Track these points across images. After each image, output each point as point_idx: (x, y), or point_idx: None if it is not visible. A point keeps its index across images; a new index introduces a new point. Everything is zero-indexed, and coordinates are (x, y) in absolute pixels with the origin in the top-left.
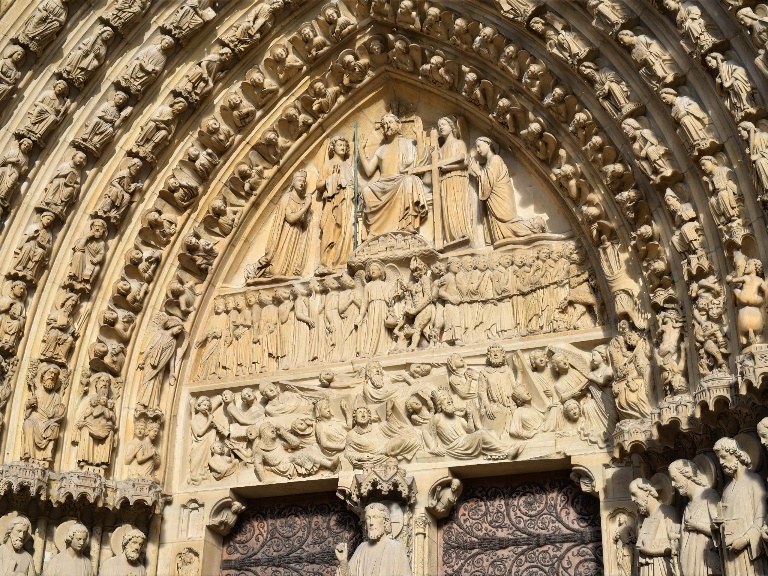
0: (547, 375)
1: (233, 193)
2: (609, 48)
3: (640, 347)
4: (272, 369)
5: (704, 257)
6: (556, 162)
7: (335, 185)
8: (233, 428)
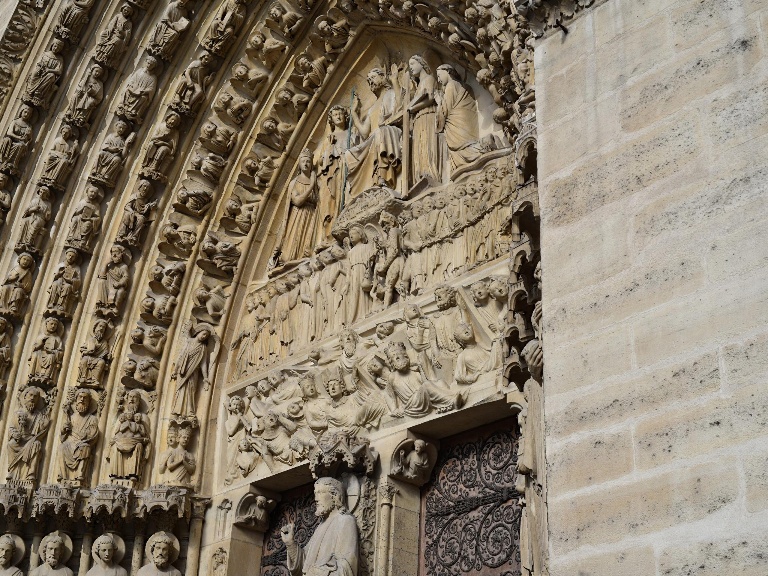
0: (491, 308)
1: (247, 190)
2: None
3: None
4: None
5: None
6: None
7: (328, 157)
8: (253, 423)
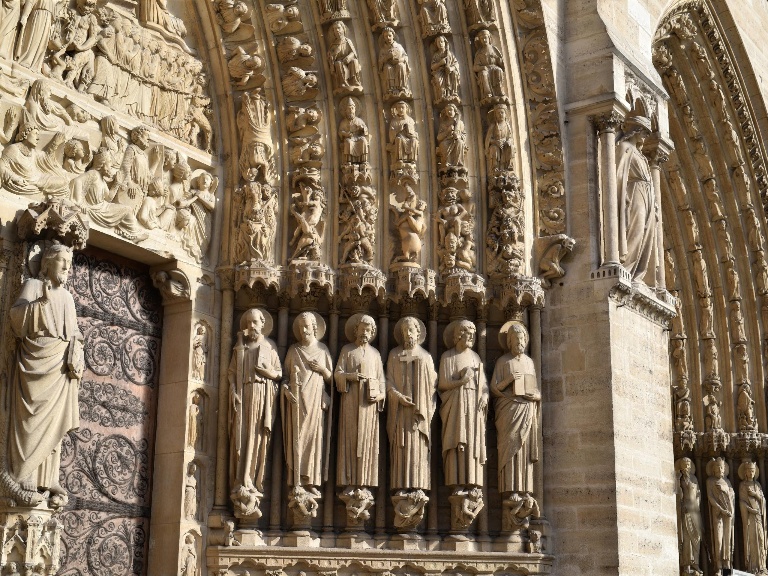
0: None
1: None
2: None
3: (272, 201)
4: None
5: None
6: None
7: None
8: None
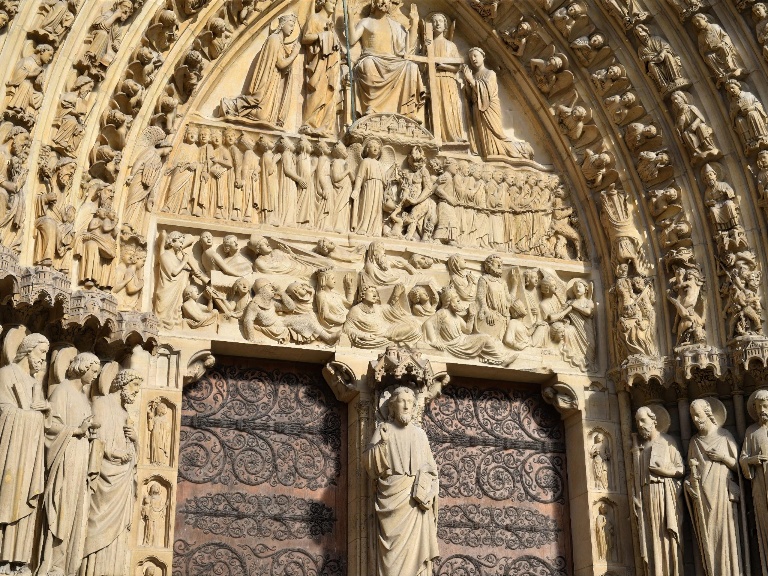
0: (534, 294)
1: (227, 15)
2: (666, 20)
3: (646, 292)
4: (255, 221)
5: (744, 234)
6: (557, 98)
7: (331, 44)
8: (215, 275)
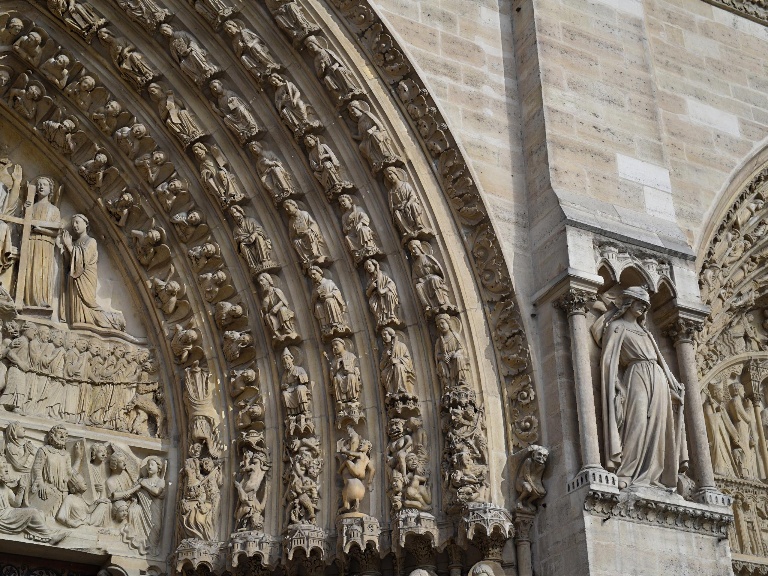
0: (101, 470)
1: None
2: (262, 204)
3: (214, 474)
4: None
5: None
6: (156, 272)
7: None
8: None
